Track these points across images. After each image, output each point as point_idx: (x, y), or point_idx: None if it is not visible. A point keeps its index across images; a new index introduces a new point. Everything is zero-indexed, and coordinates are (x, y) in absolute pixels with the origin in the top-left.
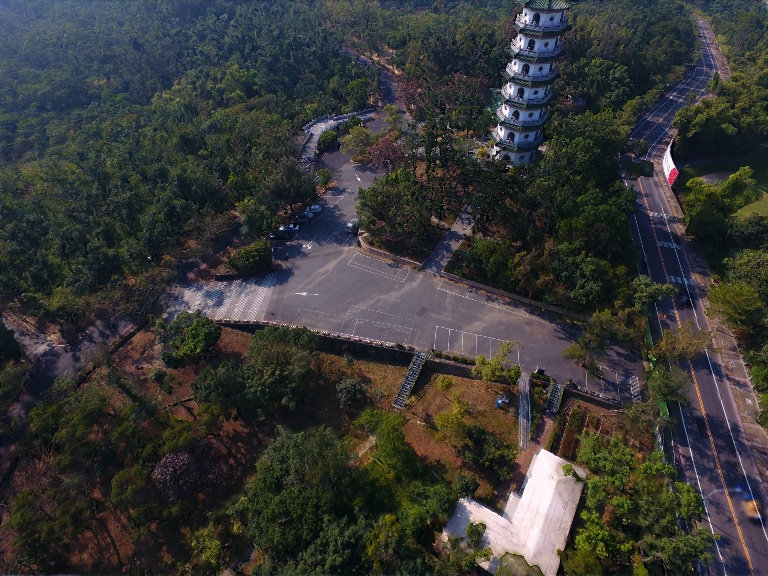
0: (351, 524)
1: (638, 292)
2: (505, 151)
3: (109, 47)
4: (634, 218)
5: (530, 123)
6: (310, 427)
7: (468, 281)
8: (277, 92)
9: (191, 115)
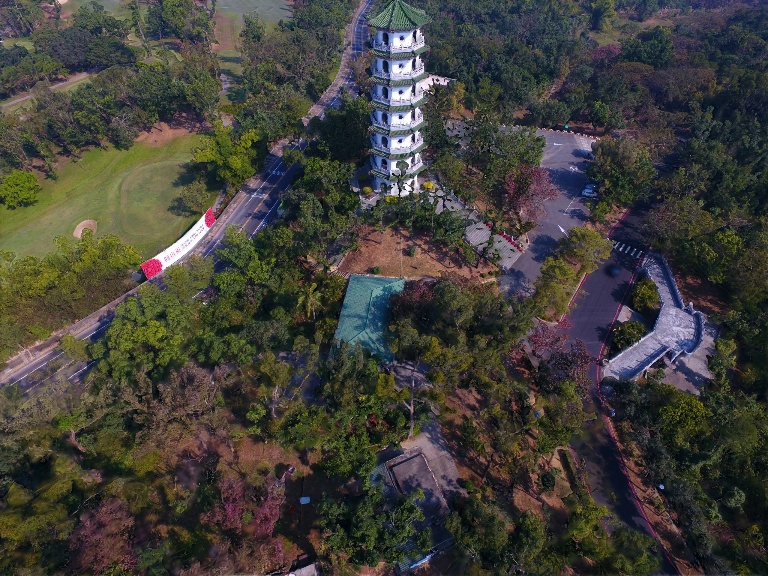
0: (493, 80)
1: None
2: None
3: None
4: None
5: None
6: (522, 124)
7: None
8: None
9: None
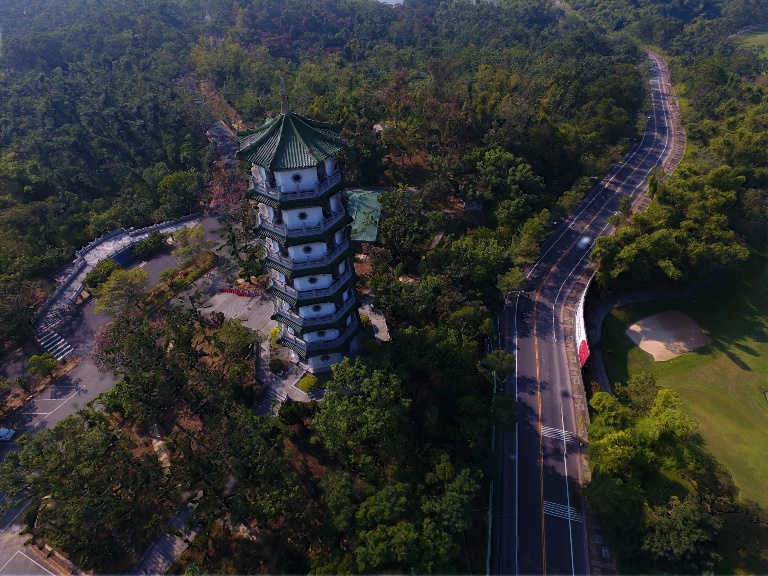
0: None
1: None
2: None
3: None
4: (515, 442)
5: (317, 320)
6: None
7: None
8: None
9: None
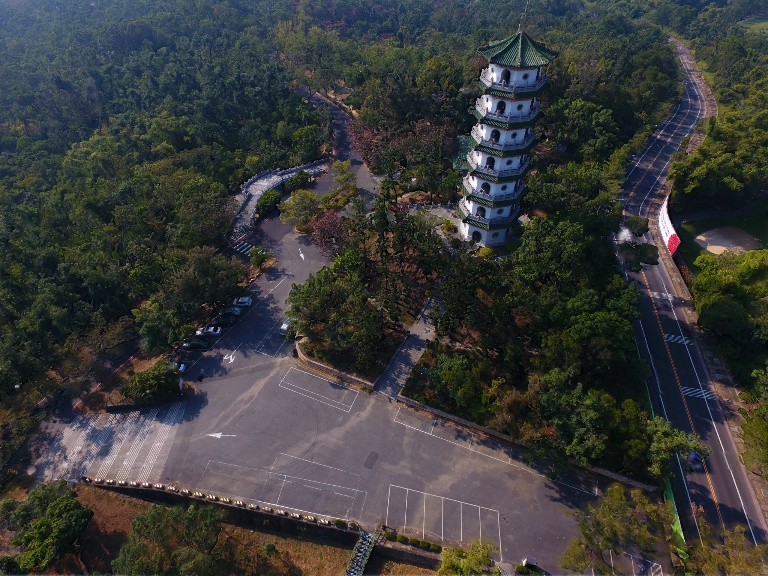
0: None
1: (654, 440)
2: (475, 227)
3: (35, 84)
4: None
5: (504, 197)
6: None
7: (432, 409)
8: (213, 142)
9: (112, 170)
